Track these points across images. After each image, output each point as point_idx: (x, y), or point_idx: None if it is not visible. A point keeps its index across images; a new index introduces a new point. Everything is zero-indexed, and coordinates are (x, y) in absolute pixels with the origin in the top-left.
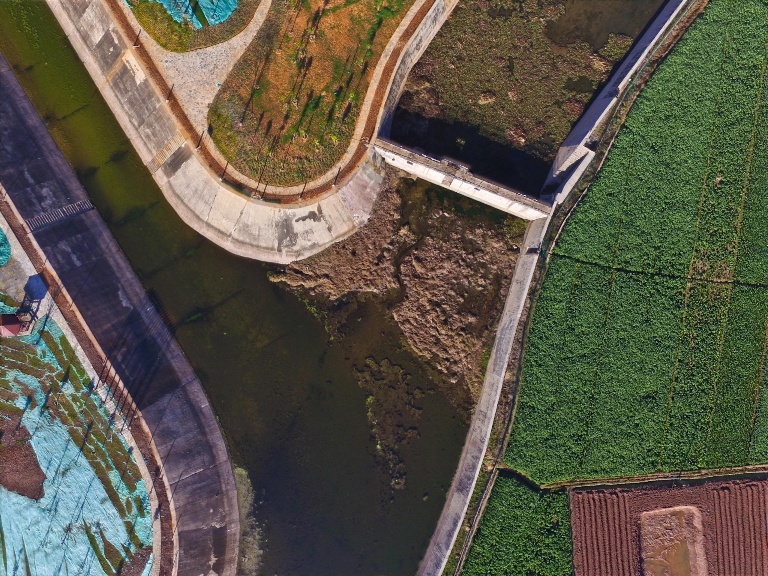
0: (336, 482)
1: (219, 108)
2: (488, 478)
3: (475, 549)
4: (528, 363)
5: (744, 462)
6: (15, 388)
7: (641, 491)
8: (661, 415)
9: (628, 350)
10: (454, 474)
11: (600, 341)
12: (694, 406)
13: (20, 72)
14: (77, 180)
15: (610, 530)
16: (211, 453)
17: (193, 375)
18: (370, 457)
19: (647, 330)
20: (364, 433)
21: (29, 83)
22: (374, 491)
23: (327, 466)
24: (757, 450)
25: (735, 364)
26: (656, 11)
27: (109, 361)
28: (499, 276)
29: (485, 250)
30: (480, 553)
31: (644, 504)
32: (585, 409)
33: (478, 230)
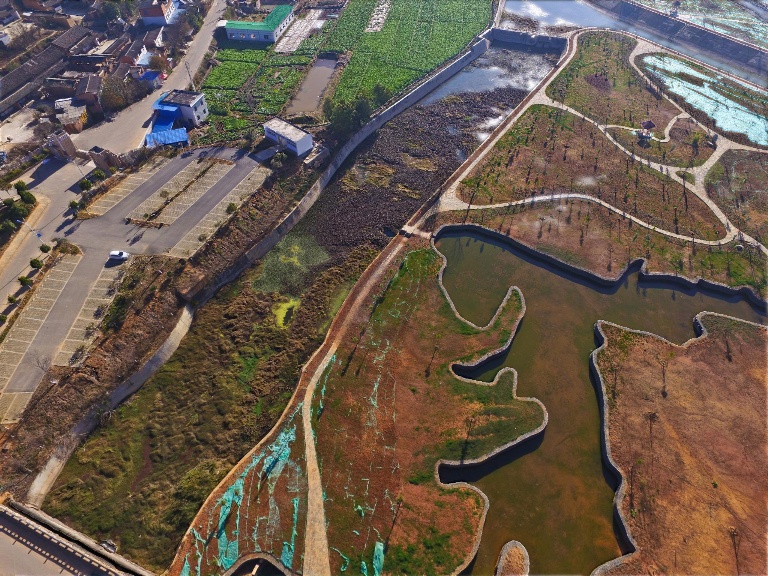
0: (546, 1)
1: (634, 42)
2: None
3: None
4: None
5: None
6: (667, 3)
7: None
8: None
9: None
10: (506, 2)
11: None
12: (428, 3)
13: (724, 62)
14: (680, 43)
15: None
16: (592, 2)
17: (607, 14)
18: (536, 4)
19: None
20: (540, 7)
21: (718, 60)
22: (532, 0)
23: (550, 3)
24: None
25: None
26: (453, 77)
27: (638, 6)
28: None
29: None
30: None
31: None
32: None
33: None
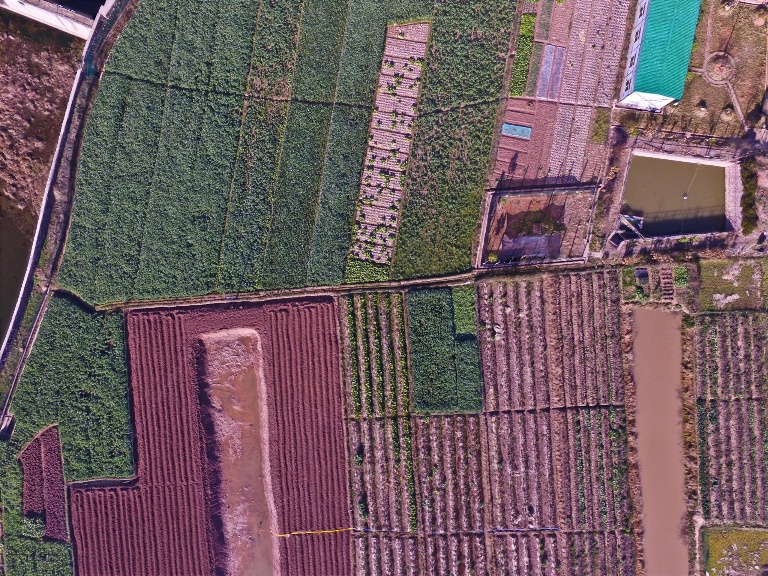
0: None
1: None
2: (42, 299)
3: (25, 368)
4: (78, 182)
5: (302, 283)
6: None
7: (197, 313)
8: (214, 235)
9: (179, 168)
10: None
11: (151, 159)
12: (249, 226)
13: None
14: None
15: (166, 352)
16: None
17: None
18: None
19: (199, 148)
20: None
21: None
22: None
23: None
24: (314, 271)
25: (292, 183)
26: None
27: None
28: (66, 100)
29: (51, 74)
30: (30, 372)
31: (200, 326)
32: (137, 229)
33: (42, 52)
